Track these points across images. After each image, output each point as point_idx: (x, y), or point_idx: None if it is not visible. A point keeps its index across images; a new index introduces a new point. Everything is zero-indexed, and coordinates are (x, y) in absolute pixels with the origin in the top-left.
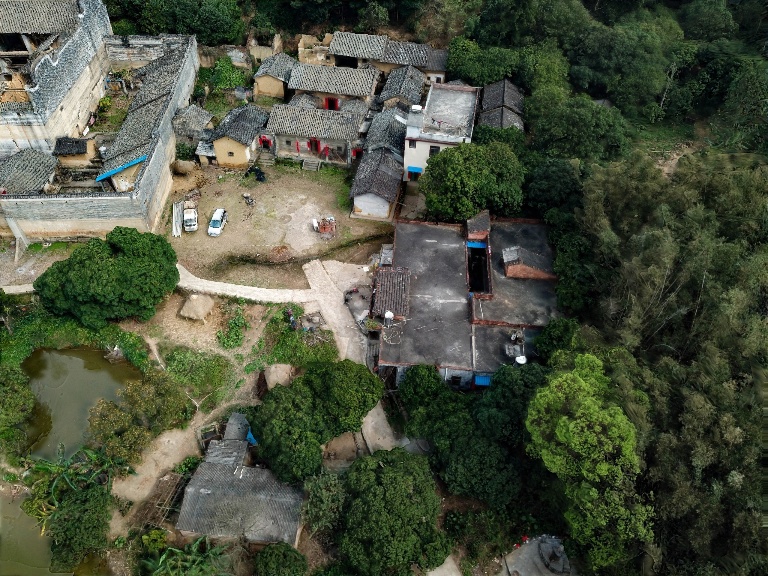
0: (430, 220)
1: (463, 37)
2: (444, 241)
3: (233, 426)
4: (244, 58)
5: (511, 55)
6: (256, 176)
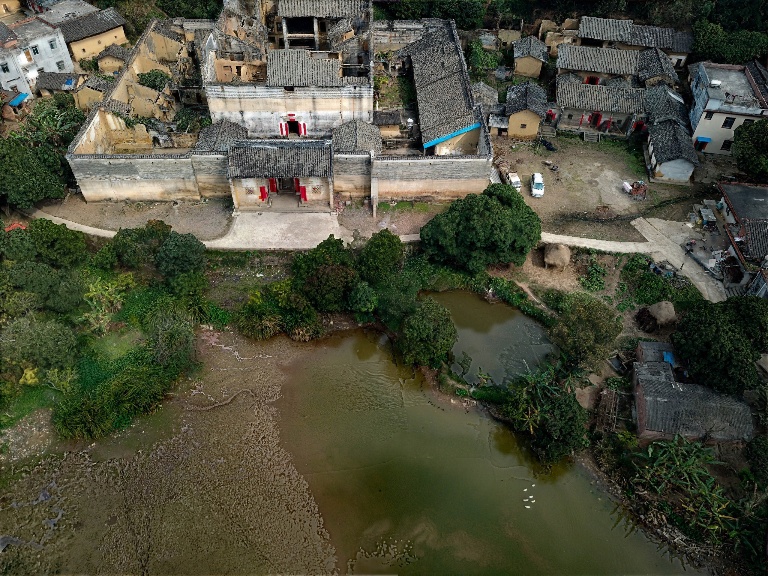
0: None
1: (707, 21)
2: None
3: (648, 351)
4: (494, 41)
5: (763, 37)
6: (545, 146)
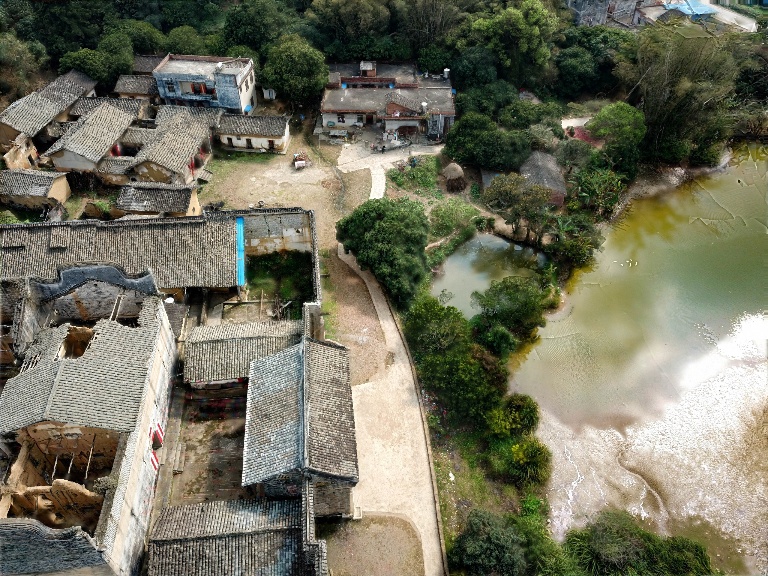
0: (292, 119)
1: None
2: (342, 95)
3: None
4: None
5: None
6: None
